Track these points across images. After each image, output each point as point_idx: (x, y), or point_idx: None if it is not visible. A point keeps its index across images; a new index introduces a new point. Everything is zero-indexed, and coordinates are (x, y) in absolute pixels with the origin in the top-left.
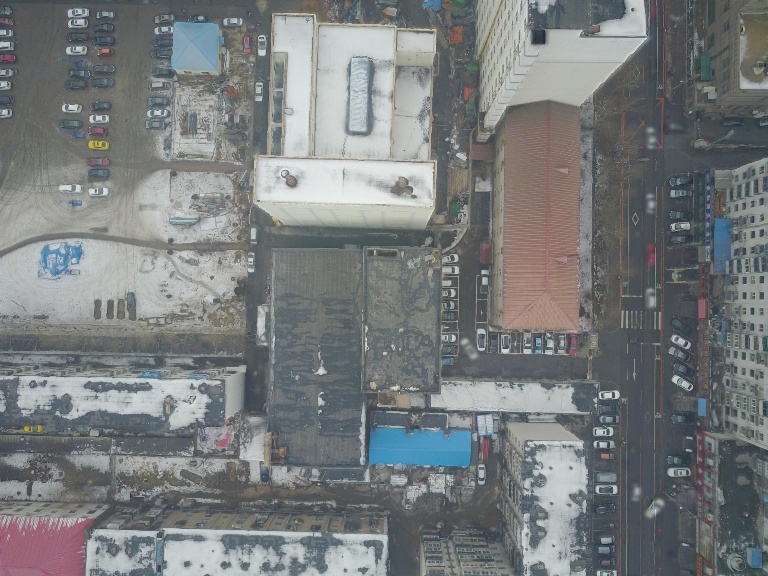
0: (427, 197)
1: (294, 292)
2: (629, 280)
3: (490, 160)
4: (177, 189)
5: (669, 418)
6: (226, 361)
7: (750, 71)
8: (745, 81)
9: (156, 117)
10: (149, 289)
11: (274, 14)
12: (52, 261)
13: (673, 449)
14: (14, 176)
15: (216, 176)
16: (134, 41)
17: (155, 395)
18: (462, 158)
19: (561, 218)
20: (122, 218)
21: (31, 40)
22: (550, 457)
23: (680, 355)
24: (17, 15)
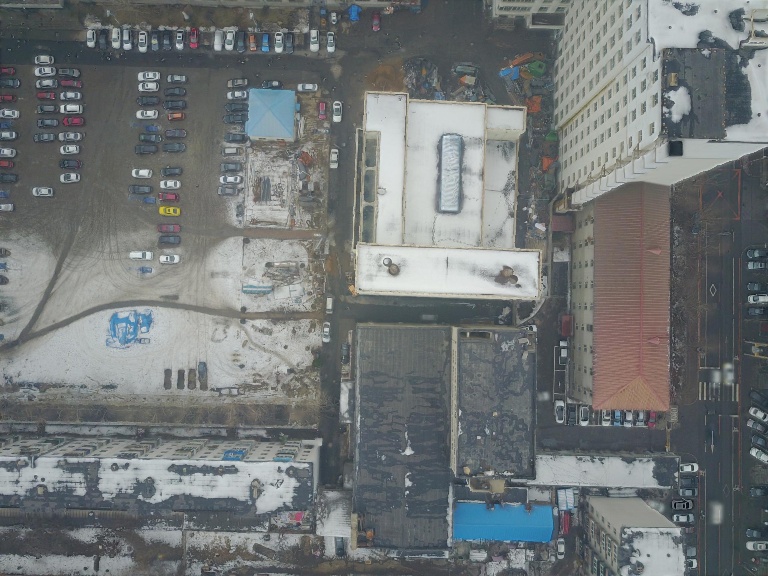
0: (532, 286)
1: (380, 370)
2: (707, 351)
3: (569, 231)
4: (250, 257)
5: (748, 491)
6: (300, 432)
7: None
8: None
9: (229, 183)
10: (221, 359)
11: (367, 92)
12: (122, 330)
13: (752, 522)
14: (81, 242)
15: (290, 244)
16: (206, 105)
17: (241, 478)
18: (541, 229)
19: (653, 299)
20: (193, 286)
21: (100, 103)
22: (647, 544)
23: (759, 428)
24: (85, 77)
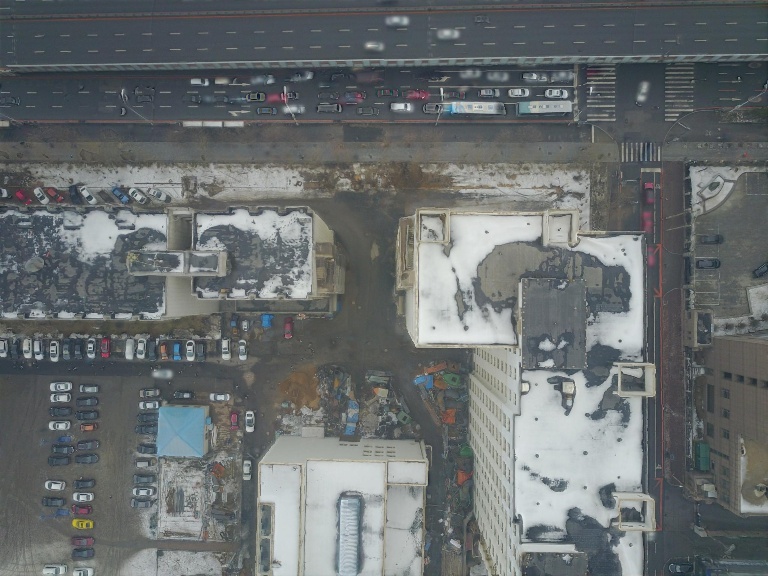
0: None
1: None
2: None
3: None
4: (164, 569)
5: None
6: None
7: (751, 494)
8: (746, 504)
9: (142, 496)
10: None
11: (260, 463)
12: None
13: None
14: None
15: (204, 557)
16: (118, 414)
17: None
18: (456, 545)
19: None
20: None
21: (13, 412)
22: None
23: None
24: None
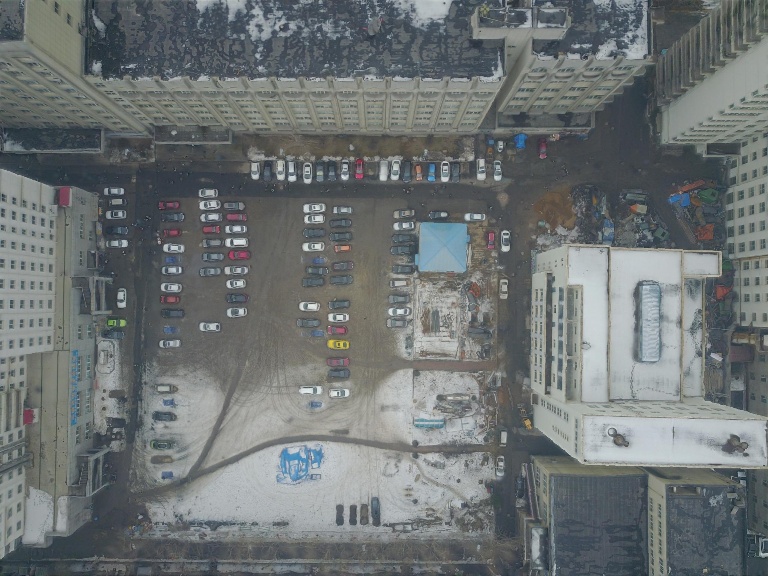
0: (759, 455)
1: (575, 519)
2: None
3: (746, 361)
4: (420, 389)
5: None
6: (475, 567)
7: None
8: None
9: (398, 315)
10: (393, 493)
11: (568, 246)
12: (294, 467)
13: None
14: (249, 377)
15: (461, 376)
16: (372, 236)
17: None
18: (717, 359)
19: None
20: (363, 420)
21: (264, 235)
22: None
23: None
24: (249, 209)
